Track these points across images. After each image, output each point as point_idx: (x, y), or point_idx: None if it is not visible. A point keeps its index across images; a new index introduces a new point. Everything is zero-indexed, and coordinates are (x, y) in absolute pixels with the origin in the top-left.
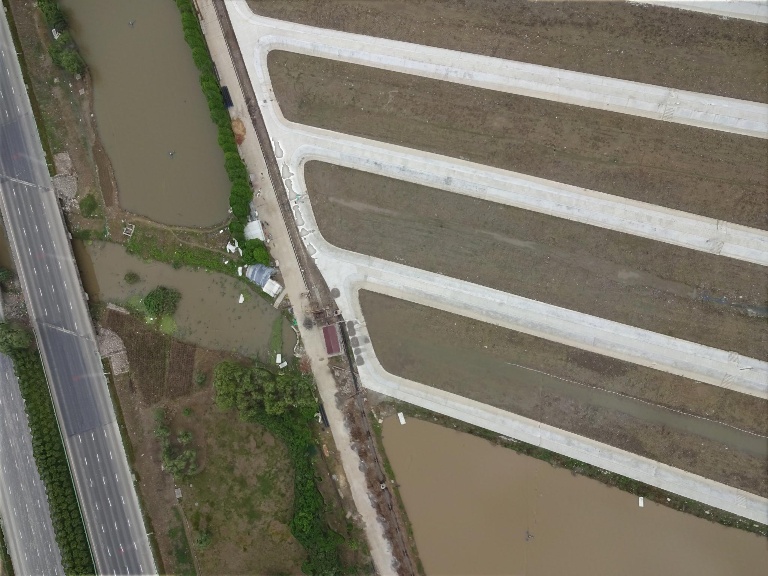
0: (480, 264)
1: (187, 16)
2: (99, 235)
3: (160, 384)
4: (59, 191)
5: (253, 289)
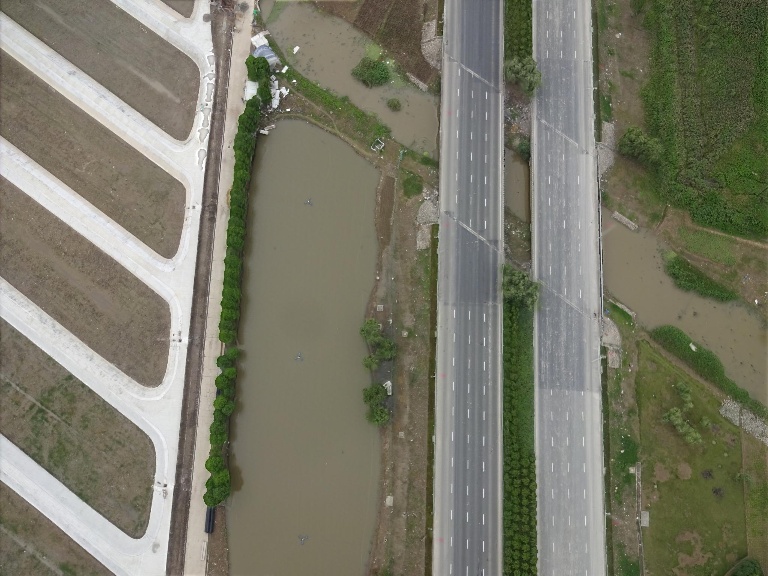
0: (84, 3)
1: (223, 313)
2: (411, 154)
3: (398, 4)
4: (436, 208)
5: (281, 53)
